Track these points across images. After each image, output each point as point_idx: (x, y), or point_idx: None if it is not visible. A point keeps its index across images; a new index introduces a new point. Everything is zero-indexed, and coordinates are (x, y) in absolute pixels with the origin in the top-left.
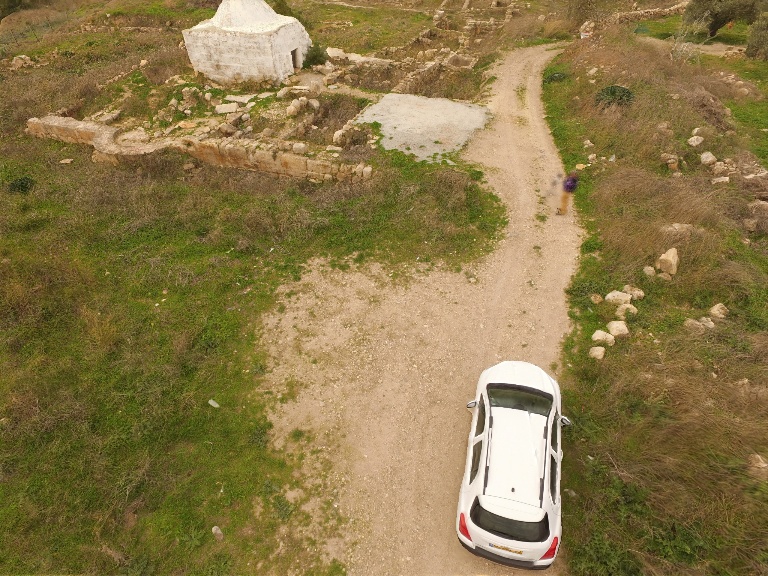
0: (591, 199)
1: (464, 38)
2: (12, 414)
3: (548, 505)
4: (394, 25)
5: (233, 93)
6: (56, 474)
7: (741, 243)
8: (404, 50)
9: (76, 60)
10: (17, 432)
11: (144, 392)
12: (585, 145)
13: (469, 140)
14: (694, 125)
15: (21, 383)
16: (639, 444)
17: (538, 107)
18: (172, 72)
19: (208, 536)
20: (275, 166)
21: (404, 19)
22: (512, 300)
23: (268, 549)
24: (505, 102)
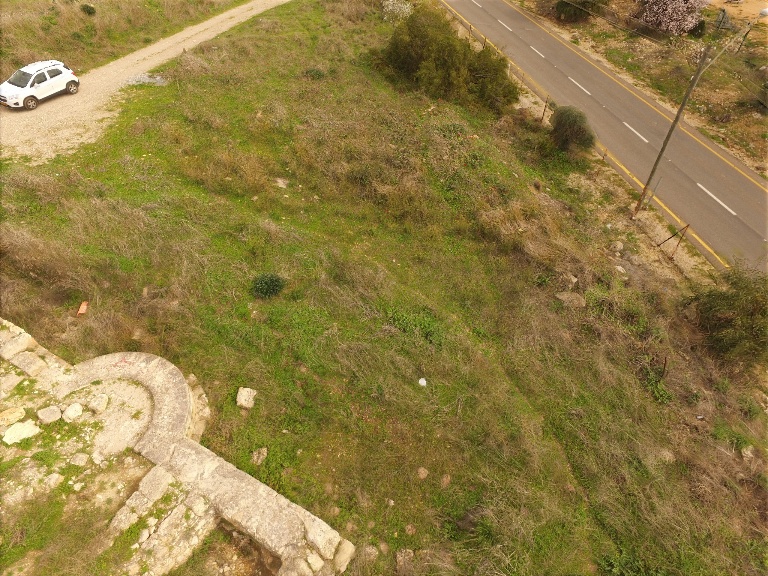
0: None
1: None
2: None
3: None
4: None
5: None
6: None
7: None
8: None
9: None
10: None
11: None
12: None
13: None
14: None
15: None
16: None
17: None
18: None
19: None
20: None
21: None
22: None
23: None
24: None
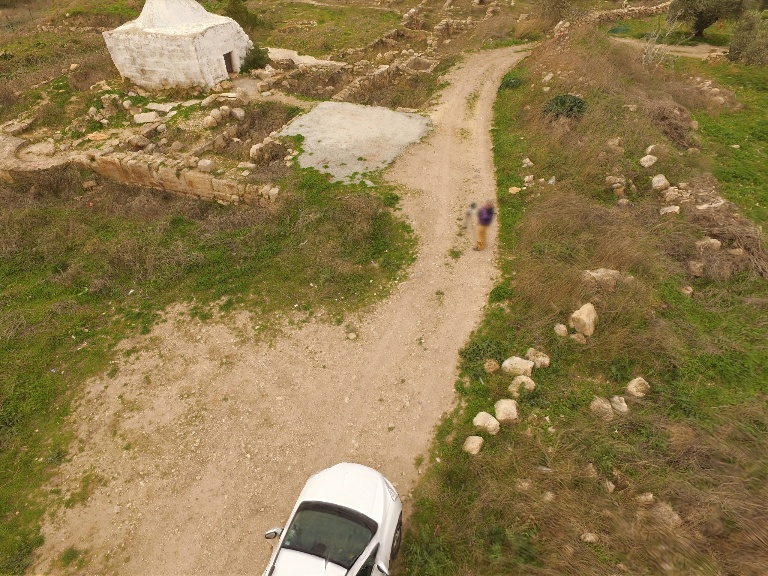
0: (516, 231)
1: (433, 39)
2: None
3: None
4: (359, 25)
5: (157, 101)
6: None
7: (680, 293)
8: (363, 52)
9: (14, 63)
10: None
11: None
12: (523, 164)
13: (398, 156)
14: (649, 142)
15: None
16: None
17: (487, 117)
18: (104, 77)
19: None
20: (180, 185)
21: (372, 18)
22: (392, 364)
23: None
24: (452, 111)
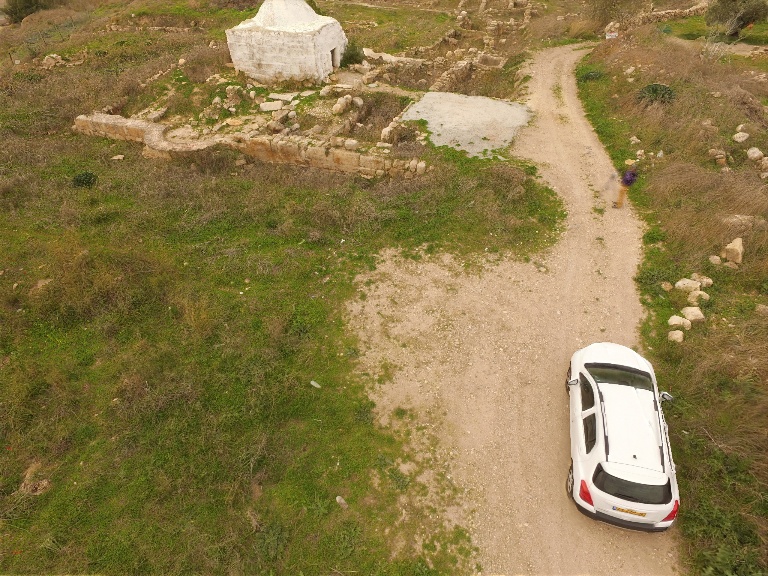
0: (645, 193)
1: (489, 38)
2: (124, 394)
3: (669, 470)
4: (419, 25)
5: (276, 91)
6: (178, 449)
7: None
8: (432, 50)
9: (110, 59)
10: (135, 410)
11: (247, 374)
12: (632, 141)
13: (515, 137)
14: (738, 122)
15: (125, 366)
16: (732, 419)
17: (577, 105)
18: (210, 71)
19: (333, 505)
20: (327, 162)
21: (428, 19)
22: (584, 288)
23: (393, 516)
24: (544, 100)
